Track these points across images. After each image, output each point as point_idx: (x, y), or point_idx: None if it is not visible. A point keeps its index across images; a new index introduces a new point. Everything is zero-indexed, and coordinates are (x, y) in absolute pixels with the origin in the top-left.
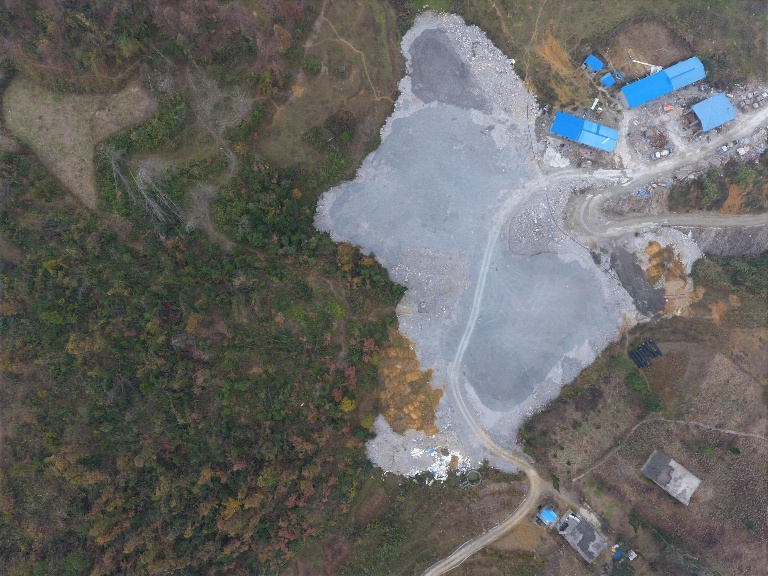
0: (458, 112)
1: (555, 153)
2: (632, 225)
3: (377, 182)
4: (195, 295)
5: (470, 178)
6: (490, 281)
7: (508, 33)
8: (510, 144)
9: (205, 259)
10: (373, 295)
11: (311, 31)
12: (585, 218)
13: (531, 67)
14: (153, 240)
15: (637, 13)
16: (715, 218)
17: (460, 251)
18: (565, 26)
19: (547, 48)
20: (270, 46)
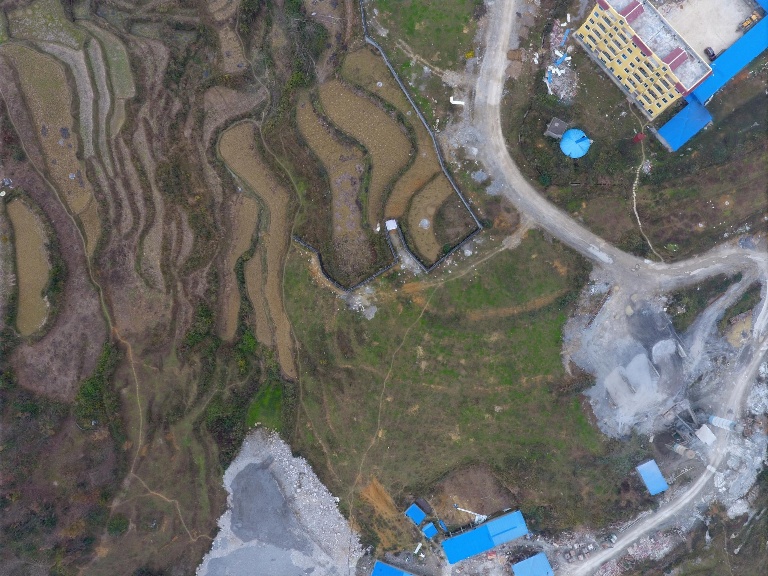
0: (277, 553)
1: None
2: None
3: None
4: None
5: None
6: None
7: (333, 472)
8: None
9: None
10: None
11: (119, 490)
12: None
13: (355, 508)
14: None
15: (463, 462)
16: None
17: None
18: (389, 473)
19: (372, 489)
20: (72, 513)
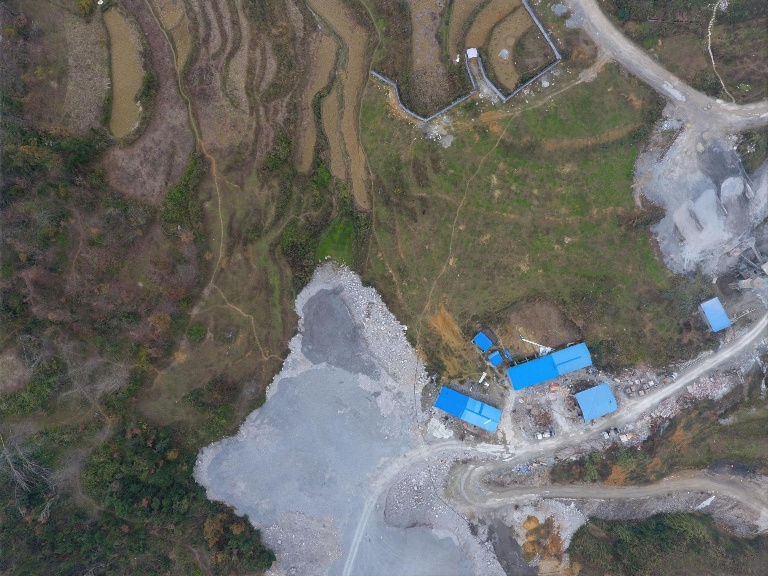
0: (346, 376)
1: (439, 424)
2: (513, 497)
3: (258, 442)
4: (49, 575)
5: (351, 444)
6: (362, 552)
7: (402, 300)
8: (395, 412)
9: (66, 532)
10: (239, 565)
11: (199, 298)
12: (466, 487)
13: (422, 336)
14: (14, 511)
15: (530, 294)
16: (599, 489)
17: (334, 519)
18: (457, 301)
19: (440, 318)
20: (154, 315)
